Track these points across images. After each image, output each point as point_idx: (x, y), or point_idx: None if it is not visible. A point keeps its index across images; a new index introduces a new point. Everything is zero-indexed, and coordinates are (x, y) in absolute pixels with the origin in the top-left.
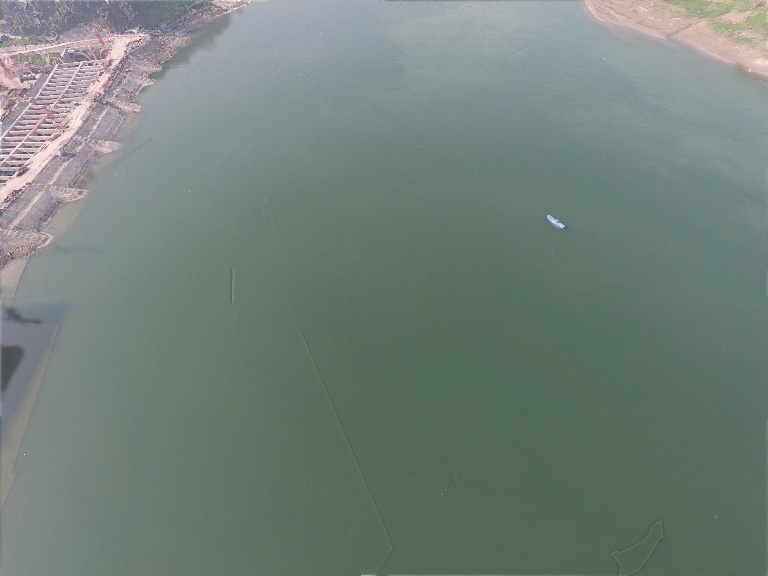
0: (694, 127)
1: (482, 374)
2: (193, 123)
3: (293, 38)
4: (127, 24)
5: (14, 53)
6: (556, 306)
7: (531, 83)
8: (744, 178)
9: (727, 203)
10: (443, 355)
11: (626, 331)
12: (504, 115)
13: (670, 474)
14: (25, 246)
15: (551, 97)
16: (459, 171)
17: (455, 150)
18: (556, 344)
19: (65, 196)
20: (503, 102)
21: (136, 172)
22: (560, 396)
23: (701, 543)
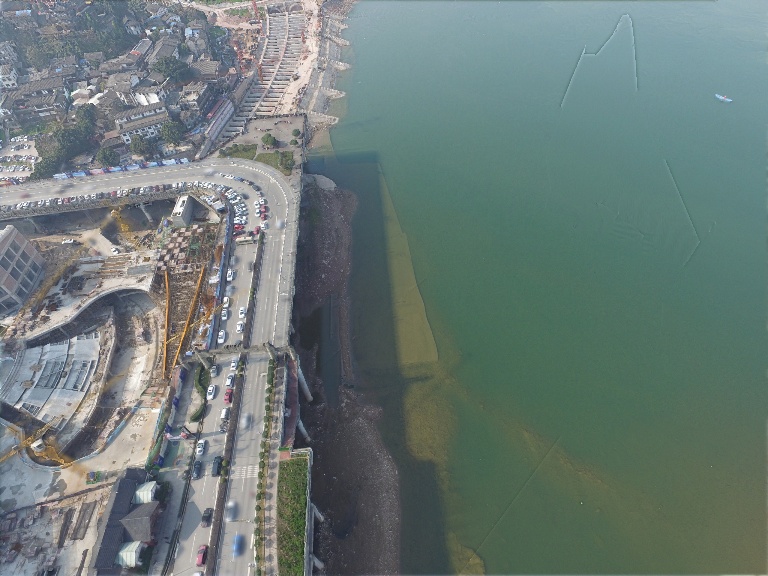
0: None
1: (701, 183)
2: None
3: None
4: None
5: (225, 8)
6: (748, 139)
7: (661, 19)
8: None
9: None
10: None
11: None
12: (648, 40)
13: None
14: (323, 122)
15: (682, 27)
16: None
17: None
18: (755, 160)
19: (332, 94)
20: (643, 32)
21: (375, 80)
22: (767, 188)
23: None
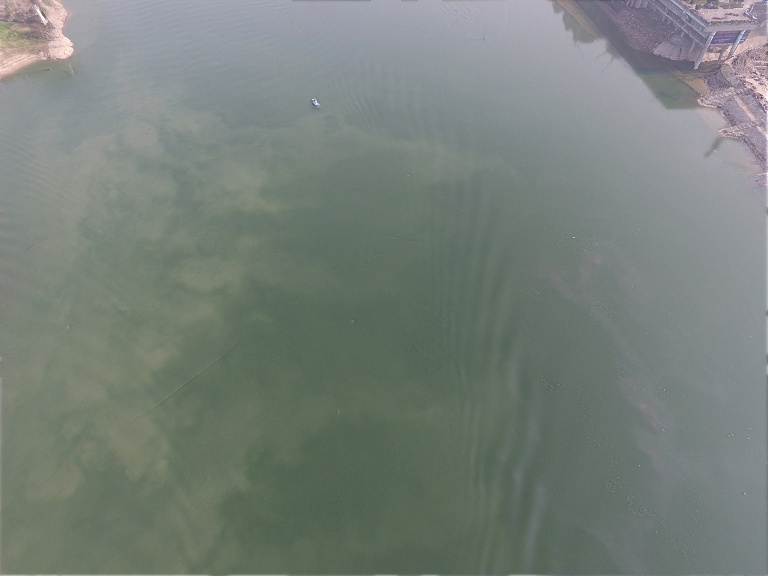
0: (108, 186)
1: (388, 60)
2: (701, 213)
3: (709, 478)
4: None
5: None
6: (343, 61)
7: (227, 276)
8: (138, 134)
9: (175, 120)
10: (406, 64)
11: (314, 52)
12: (298, 217)
13: None
14: None
15: (220, 245)
16: (373, 147)
17: (371, 170)
18: (350, 55)
19: None
20: (288, 240)
21: (696, 151)
22: (356, 49)
23: (325, 29)
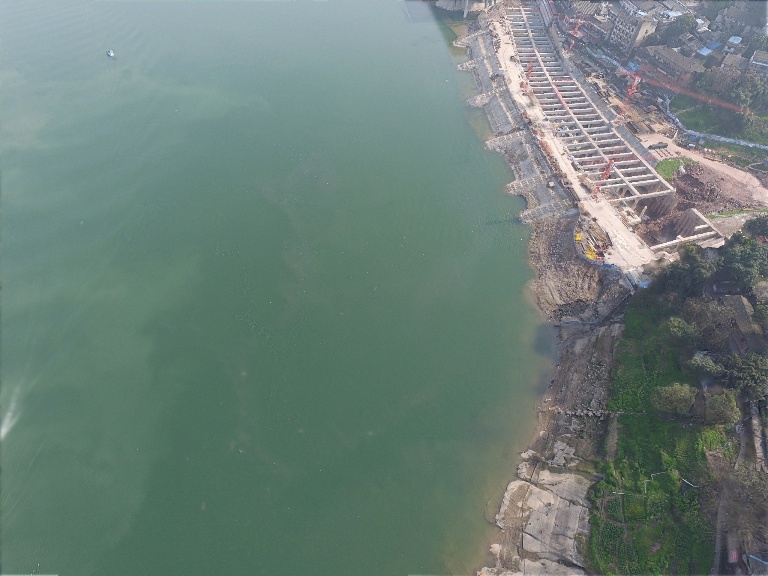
0: None
1: None
2: (411, 128)
3: (320, 306)
4: None
5: None
6: None
7: None
8: None
9: None
10: (215, 20)
11: (123, 10)
12: (64, 147)
13: (145, 0)
14: None
15: None
16: (153, 89)
17: (144, 107)
18: (159, 13)
19: None
20: (48, 165)
21: (431, 82)
22: (170, 8)
23: None
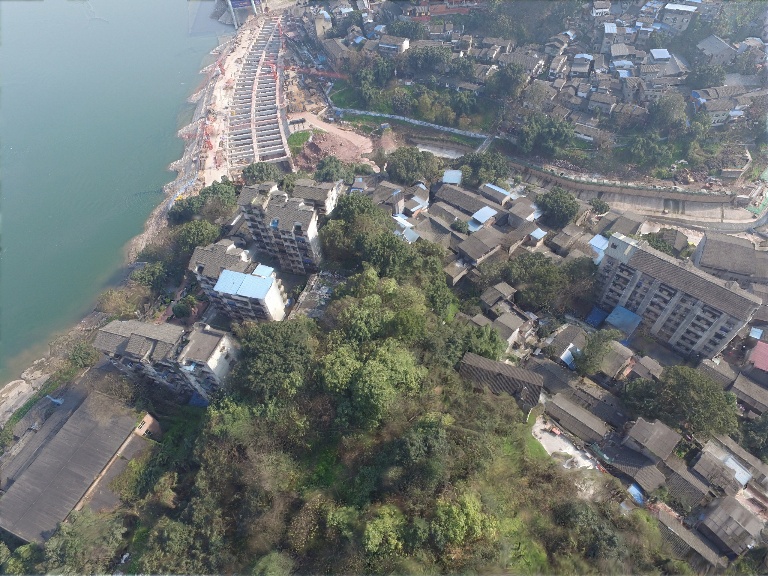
0: None
1: (14, 47)
2: (124, 124)
3: None
4: None
5: None
6: None
7: None
8: None
9: None
10: None
11: None
12: None
13: None
14: None
15: None
16: None
17: None
18: None
19: None
20: None
21: (168, 85)
22: None
23: None
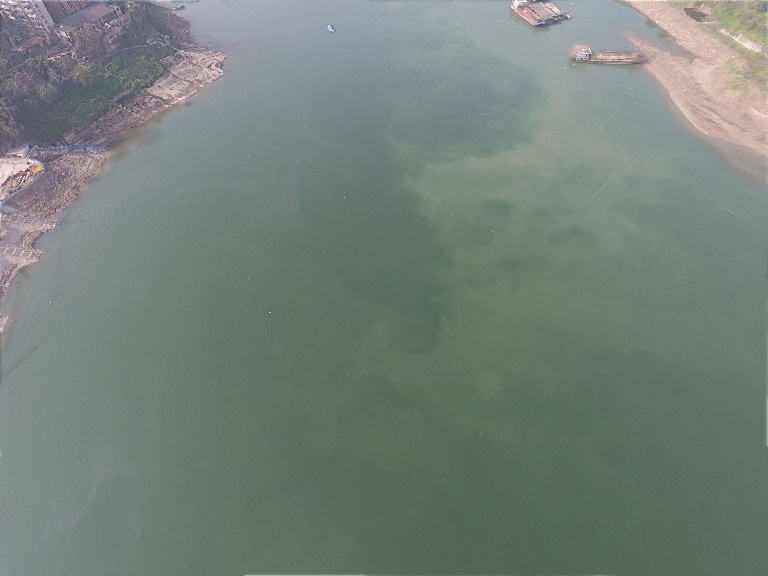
0: None
1: None
2: (89, 365)
3: (263, 160)
4: (9, 142)
5: None
6: None
7: (634, 264)
8: None
9: None
10: None
11: None
12: (609, 344)
13: None
14: None
15: (674, 299)
16: (564, 516)
17: (545, 446)
18: None
19: None
20: (600, 310)
21: None
22: None
23: None
